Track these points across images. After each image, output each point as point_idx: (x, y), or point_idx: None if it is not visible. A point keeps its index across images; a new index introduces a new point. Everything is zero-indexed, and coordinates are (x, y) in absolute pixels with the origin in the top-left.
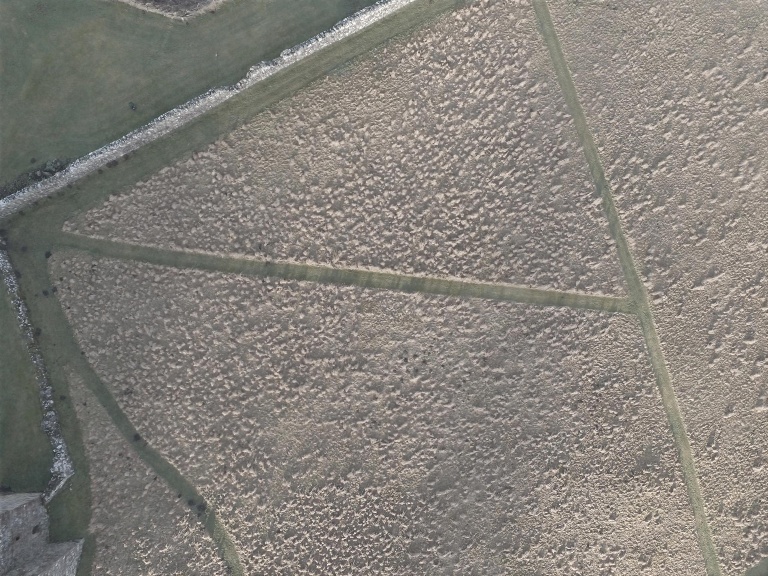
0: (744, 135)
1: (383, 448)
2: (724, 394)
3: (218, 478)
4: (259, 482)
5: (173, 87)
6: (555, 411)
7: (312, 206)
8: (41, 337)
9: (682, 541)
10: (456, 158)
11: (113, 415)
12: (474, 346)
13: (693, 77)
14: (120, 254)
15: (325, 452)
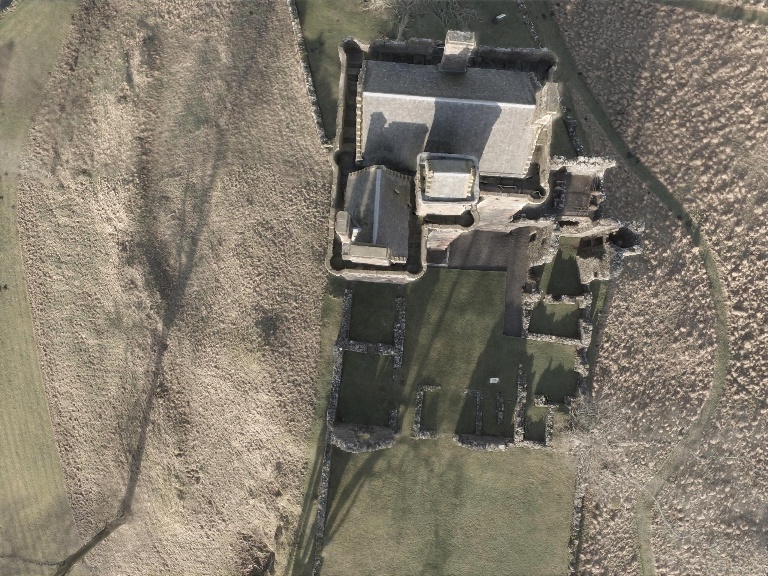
0: None
1: None
2: None
3: (702, 198)
4: (735, 207)
5: None
6: None
7: None
8: None
9: None
10: None
11: (607, 133)
12: None
13: None
14: None
15: None
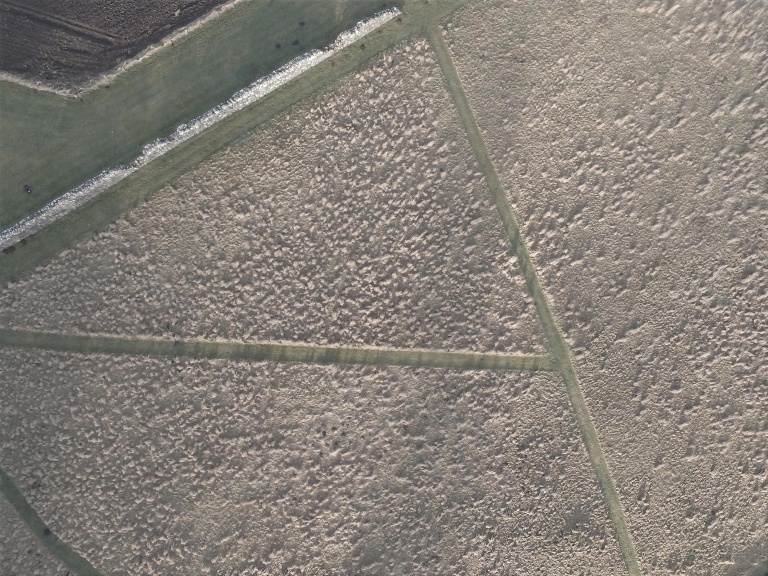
0: (660, 182)
1: (305, 525)
2: (652, 446)
3: (133, 569)
4: (177, 569)
5: (69, 167)
6: (480, 476)
7: (220, 281)
8: None
9: None
10: (366, 224)
11: (21, 511)
12: (393, 415)
13: (606, 126)
14: (22, 343)
15: (245, 533)
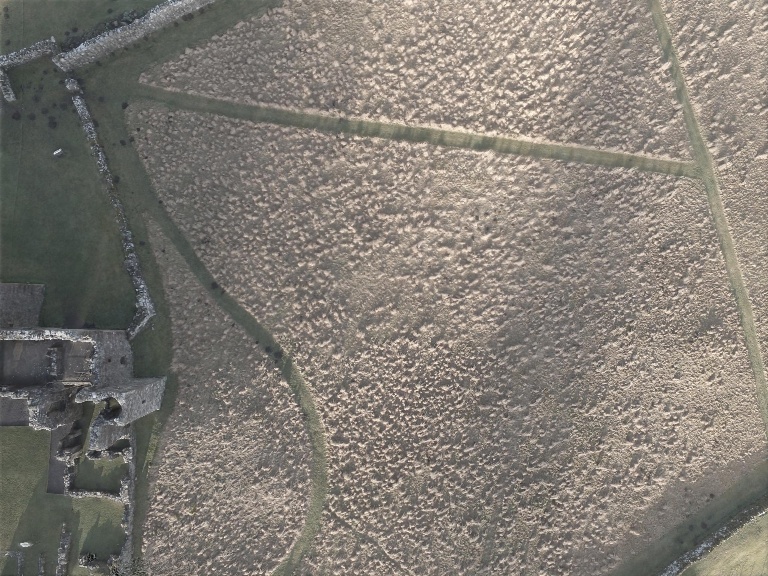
0: None
1: (454, 303)
2: None
3: (294, 327)
4: (334, 332)
5: None
6: (622, 272)
7: (385, 64)
8: (119, 185)
9: (743, 404)
10: (527, 20)
11: (191, 263)
12: (544, 206)
13: None
14: (196, 107)
15: (398, 306)
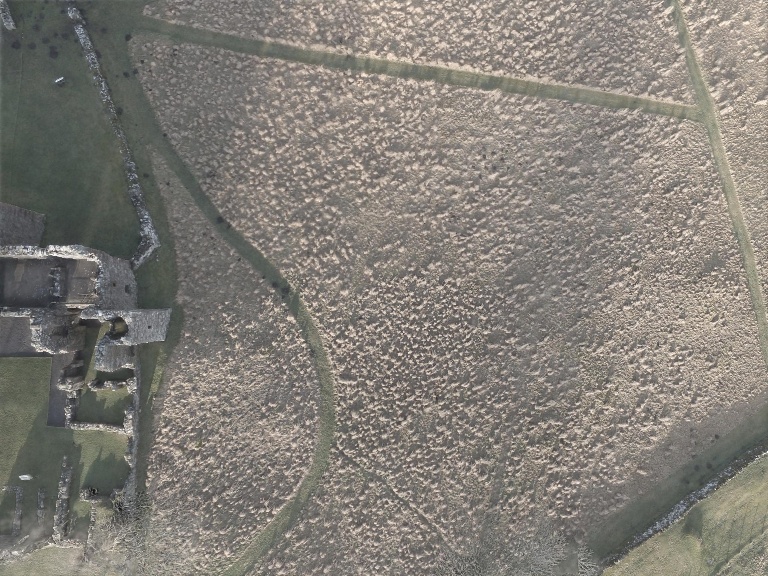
0: None
1: (462, 242)
2: None
3: (301, 262)
4: (341, 269)
5: None
6: (627, 212)
7: (392, 2)
8: (123, 116)
9: (746, 345)
10: None
11: (196, 197)
12: (550, 146)
13: None
14: (201, 41)
15: (405, 244)
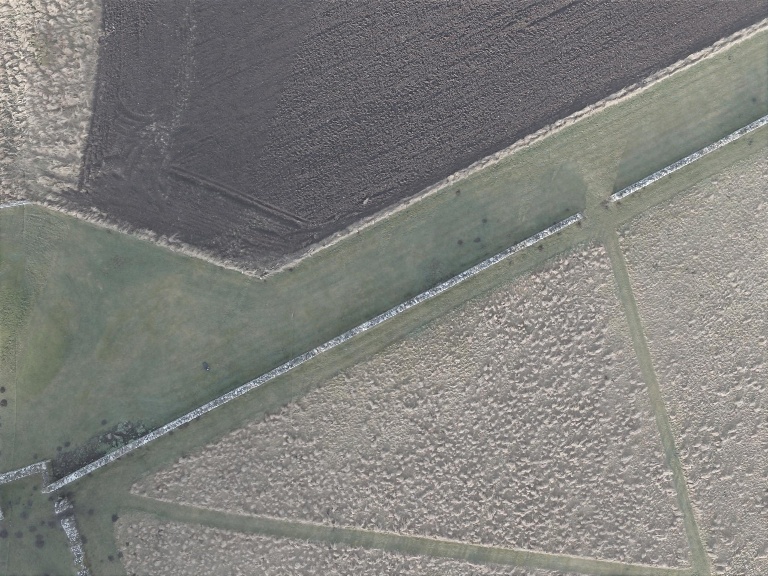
0: None
1: None
2: None
3: None
4: None
5: (248, 348)
6: None
7: (382, 472)
8: None
9: None
10: (529, 426)
11: None
12: None
13: (767, 343)
14: (187, 518)
15: None
